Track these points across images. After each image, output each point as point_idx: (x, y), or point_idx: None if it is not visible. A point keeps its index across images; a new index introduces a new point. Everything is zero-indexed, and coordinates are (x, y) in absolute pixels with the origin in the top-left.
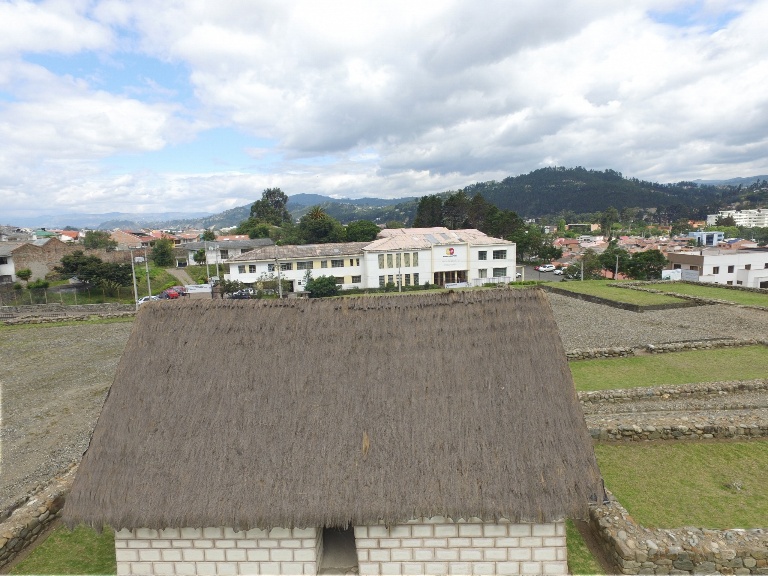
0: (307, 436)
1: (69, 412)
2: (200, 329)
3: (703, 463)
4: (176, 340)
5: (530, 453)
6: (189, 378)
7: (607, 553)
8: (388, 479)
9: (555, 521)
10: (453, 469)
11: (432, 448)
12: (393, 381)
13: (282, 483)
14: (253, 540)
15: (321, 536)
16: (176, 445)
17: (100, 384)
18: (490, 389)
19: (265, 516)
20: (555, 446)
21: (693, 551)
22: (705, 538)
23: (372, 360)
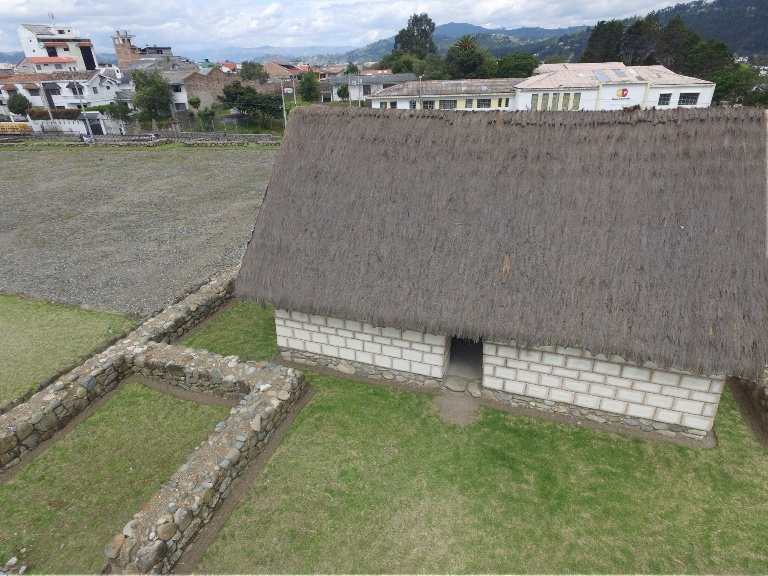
0: (446, 252)
1: (236, 220)
2: (346, 137)
3: None
4: (323, 147)
5: (702, 302)
6: (335, 185)
7: (766, 422)
8: (526, 304)
9: (712, 377)
10: (601, 305)
11: (580, 281)
12: (546, 207)
13: (418, 292)
14: (388, 338)
15: (449, 348)
16: (323, 245)
17: (259, 200)
18: (666, 227)
19: (400, 318)
20: (738, 299)
21: None
22: None
23: (524, 182)
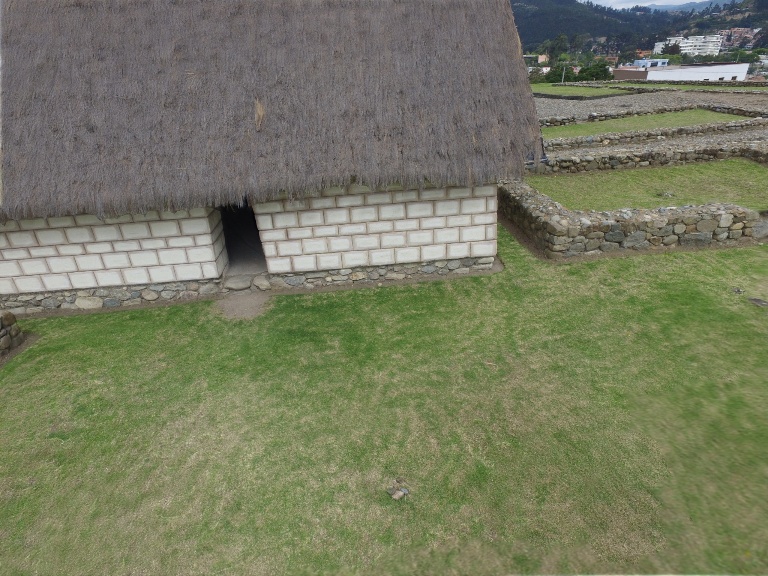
0: (180, 107)
1: None
2: None
3: (637, 183)
4: None
5: (461, 114)
6: (5, 47)
7: (538, 241)
8: (289, 148)
9: (486, 194)
10: (368, 134)
11: (343, 115)
12: (291, 45)
13: (152, 159)
14: (133, 241)
15: (223, 244)
16: None
17: None
18: (415, 49)
19: (134, 196)
20: (490, 106)
21: (626, 221)
22: (639, 212)
23: (262, 21)
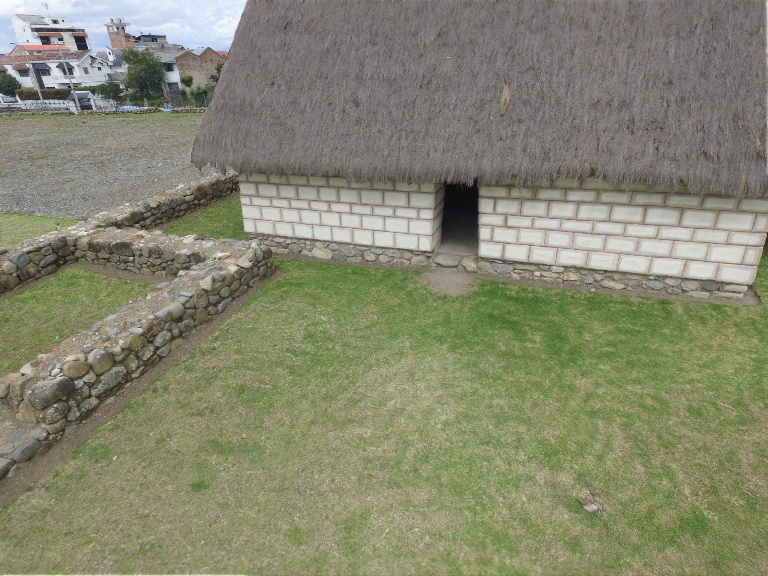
0: (434, 88)
1: None
2: None
3: None
4: None
5: (745, 111)
6: (307, 34)
7: None
8: (529, 134)
9: (757, 209)
10: (621, 126)
11: (595, 104)
12: (552, 30)
13: (401, 133)
14: (368, 205)
15: (440, 221)
16: (292, 97)
17: None
18: (698, 34)
19: (380, 165)
20: None
21: None
22: None
23: (527, 7)
